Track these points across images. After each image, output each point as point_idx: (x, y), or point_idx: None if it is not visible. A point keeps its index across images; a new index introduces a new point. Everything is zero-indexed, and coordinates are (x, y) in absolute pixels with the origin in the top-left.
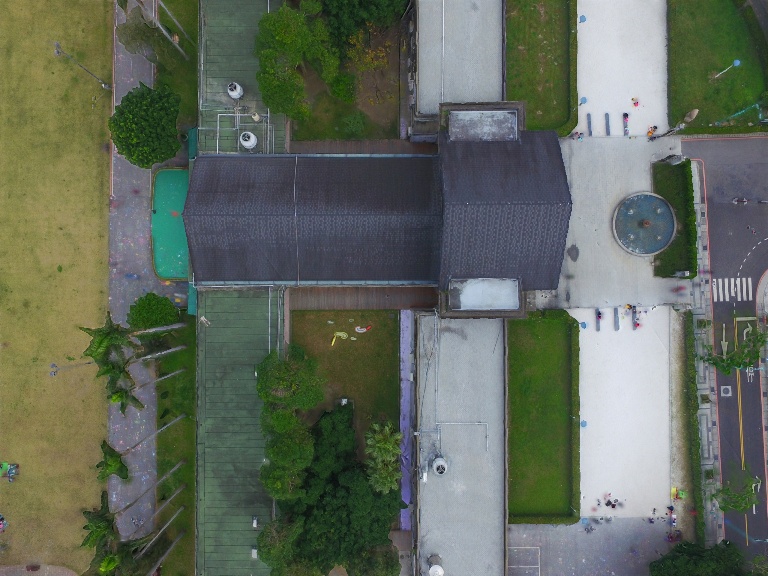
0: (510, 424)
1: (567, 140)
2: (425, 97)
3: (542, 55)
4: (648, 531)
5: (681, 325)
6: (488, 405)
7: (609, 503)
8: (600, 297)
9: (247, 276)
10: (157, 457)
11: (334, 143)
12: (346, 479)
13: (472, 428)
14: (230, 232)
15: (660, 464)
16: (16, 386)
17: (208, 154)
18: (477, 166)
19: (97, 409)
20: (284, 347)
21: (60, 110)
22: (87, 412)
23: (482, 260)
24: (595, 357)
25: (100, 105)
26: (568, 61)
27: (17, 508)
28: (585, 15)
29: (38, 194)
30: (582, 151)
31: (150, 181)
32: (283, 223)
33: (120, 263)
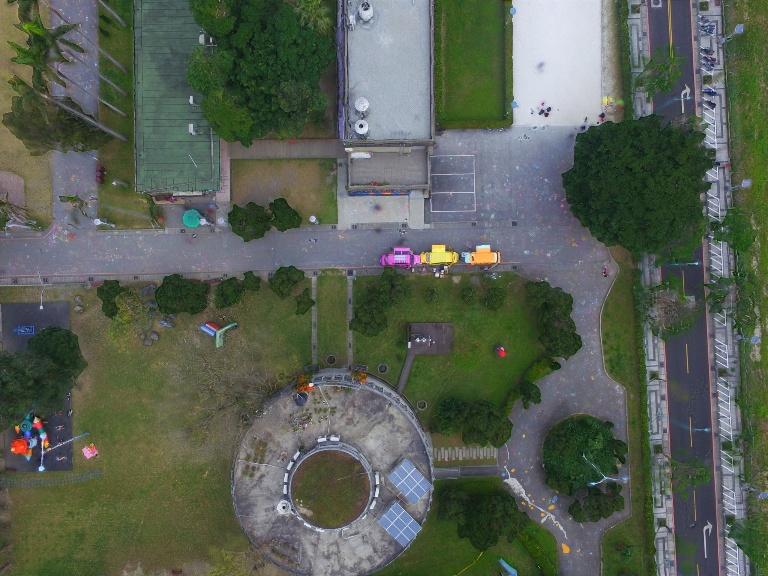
0: (445, 36)
1: None
2: None
3: None
4: None
5: None
6: None
7: (542, 111)
8: None
9: None
10: (99, 67)
11: None
12: (273, 17)
13: None
14: None
15: (592, 74)
16: None
17: None
18: None
19: None
20: None
21: None
22: None
23: None
24: None
25: None
26: None
27: None
28: None
29: None
30: None
31: None
32: None
33: None
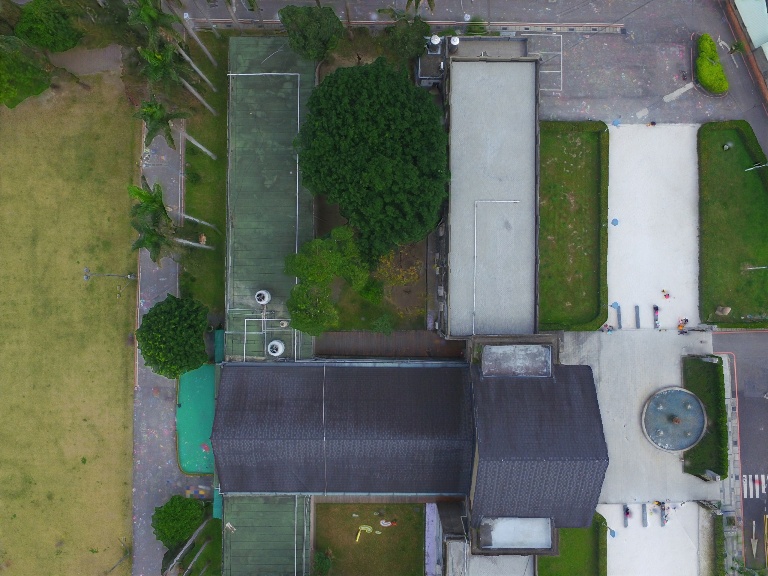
0: None
1: (596, 332)
2: (456, 317)
3: (572, 245)
4: None
5: (710, 522)
6: None
7: None
8: (628, 493)
9: (274, 488)
10: None
11: (360, 334)
12: None
13: None
14: (258, 453)
15: None
16: None
17: (235, 360)
18: (511, 411)
19: None
20: (310, 555)
21: (85, 300)
22: None
23: (515, 504)
24: (622, 553)
25: (125, 295)
26: (598, 254)
27: None
28: (616, 205)
29: (63, 385)
30: (611, 344)
31: None
32: (312, 446)
33: (144, 454)
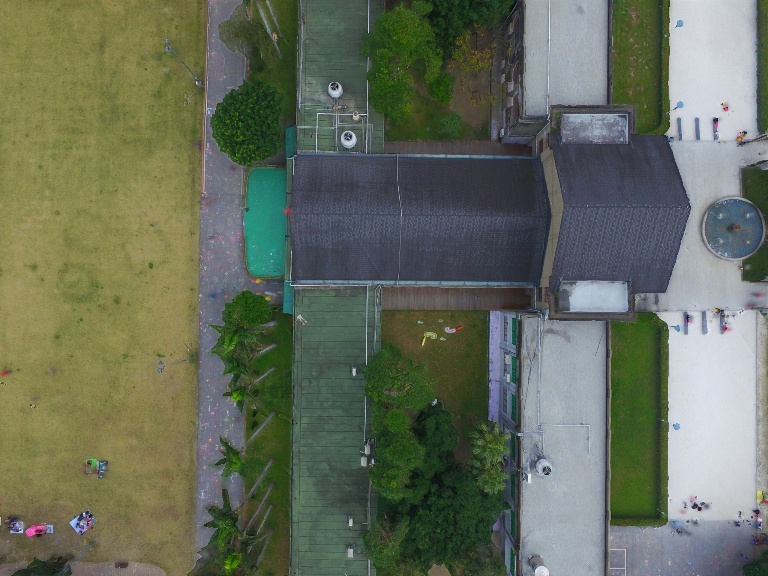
0: None
1: None
2: (530, 99)
3: (633, 59)
4: (734, 534)
5: None
6: (590, 407)
7: (695, 506)
8: (688, 301)
9: (347, 275)
10: (246, 455)
11: (425, 143)
12: (452, 479)
13: (574, 430)
14: (335, 231)
15: (746, 468)
16: (106, 382)
17: (307, 153)
18: (592, 169)
19: (186, 406)
20: (380, 347)
21: (153, 106)
22: (176, 409)
23: (595, 262)
24: (683, 360)
25: (192, 102)
26: (660, 65)
27: (106, 505)
28: (676, 20)
29: (130, 190)
30: None
31: (242, 179)
32: (388, 223)
33: (211, 260)
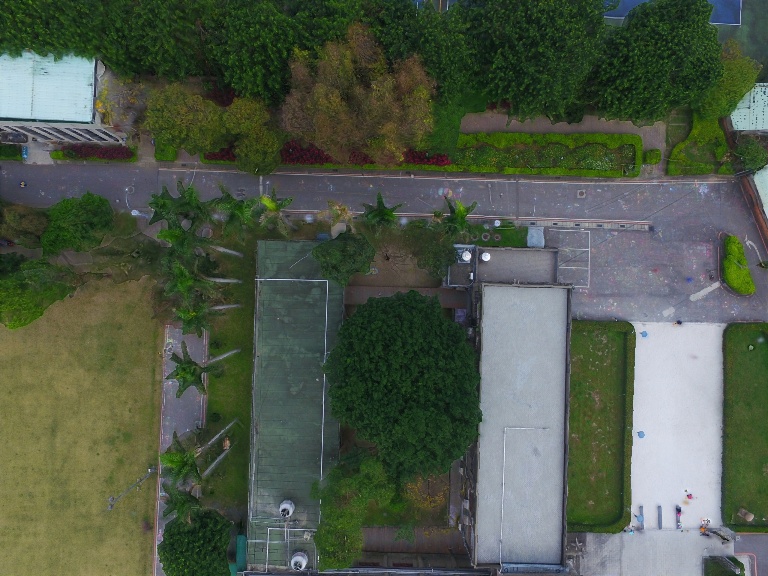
0: None
1: None
2: (483, 544)
3: (596, 444)
4: None
5: None
6: None
7: None
8: None
9: None
10: None
11: (382, 530)
12: None
13: None
14: None
15: None
16: None
17: None
18: None
19: None
20: None
21: (104, 493)
22: None
23: None
24: None
25: (145, 487)
26: (622, 455)
27: None
28: (640, 403)
29: None
30: (633, 544)
31: None
32: None
33: None
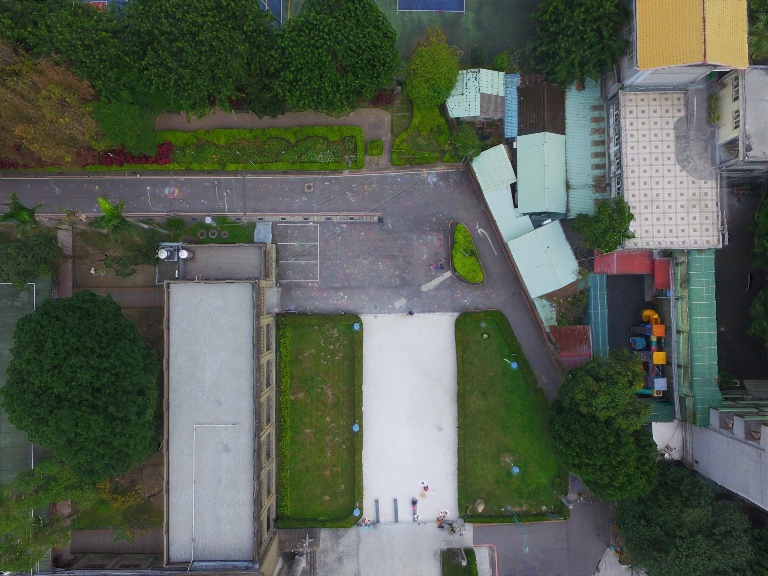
0: None
1: (355, 527)
2: (176, 542)
3: (329, 438)
4: None
5: None
6: None
7: None
8: None
9: None
10: None
11: None
12: None
13: None
14: None
15: None
16: None
17: None
18: None
19: None
20: None
21: None
22: None
23: None
24: None
25: None
26: (354, 448)
27: None
28: (374, 396)
29: None
30: (370, 538)
31: None
32: None
33: None
